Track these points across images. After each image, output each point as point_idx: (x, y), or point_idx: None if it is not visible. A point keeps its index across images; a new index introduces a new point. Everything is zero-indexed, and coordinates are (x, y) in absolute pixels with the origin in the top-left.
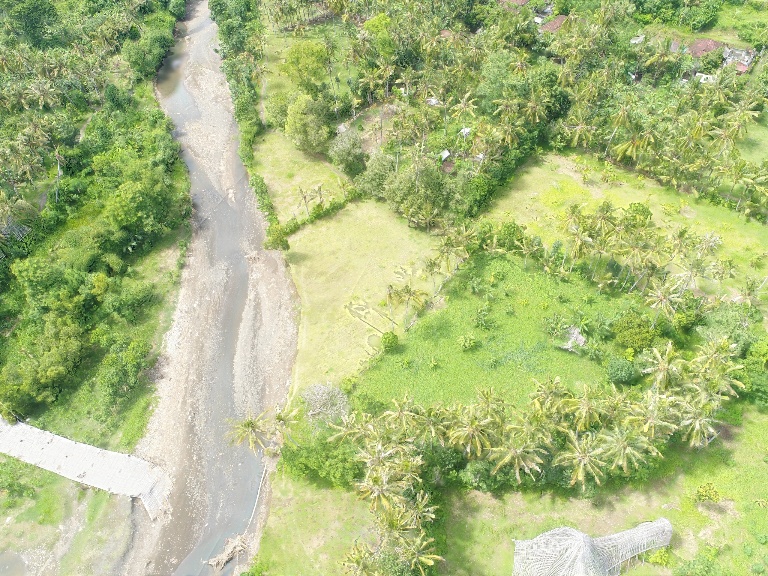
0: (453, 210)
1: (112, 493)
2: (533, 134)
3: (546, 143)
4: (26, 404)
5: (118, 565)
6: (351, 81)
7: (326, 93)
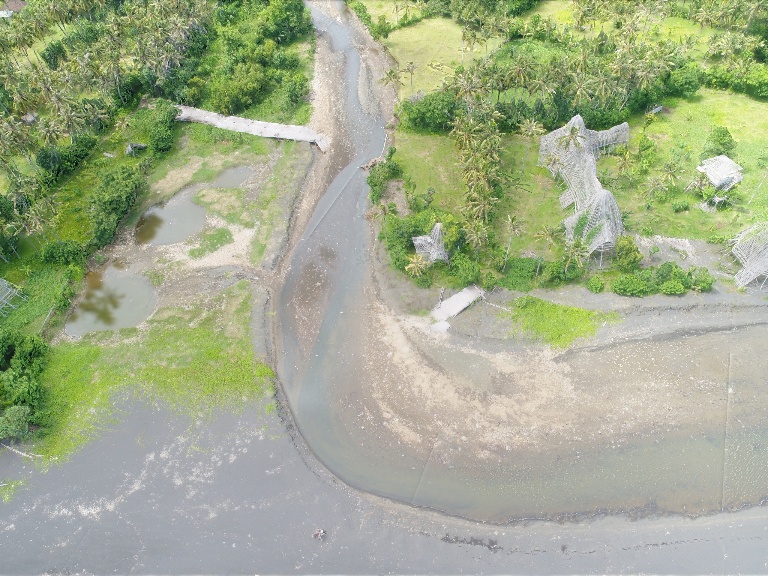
0: (498, 12)
1: (297, 141)
2: None
3: None
4: (234, 104)
5: (308, 167)
6: None
7: None
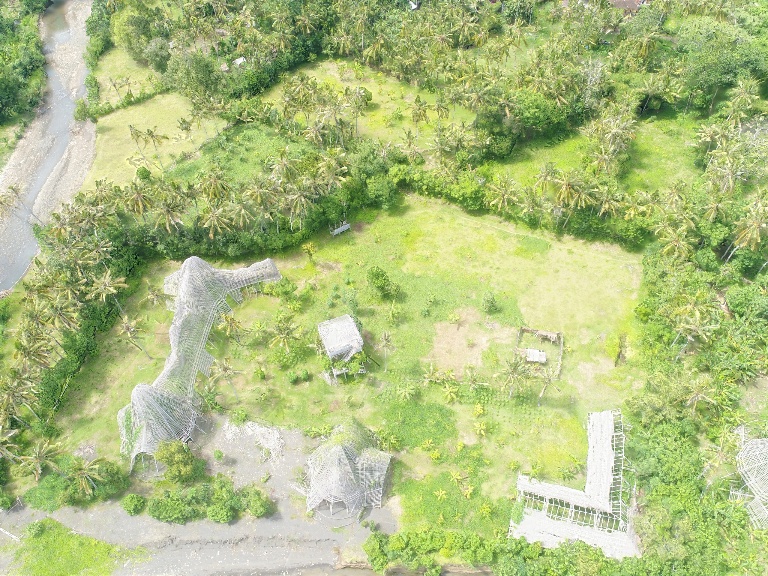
0: (221, 92)
1: None
2: (307, 43)
3: (326, 54)
4: None
5: None
6: (183, 8)
7: (161, 16)
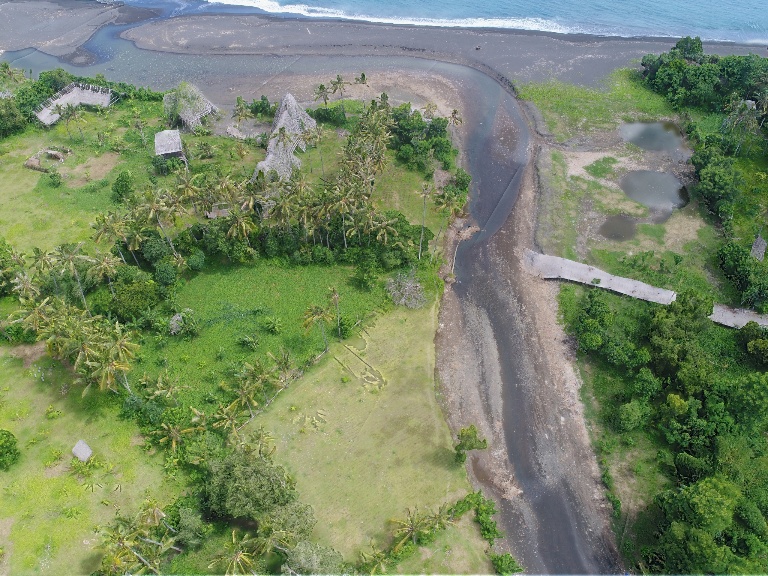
0: None
1: None
2: None
3: None
4: None
5: None
6: None
7: None
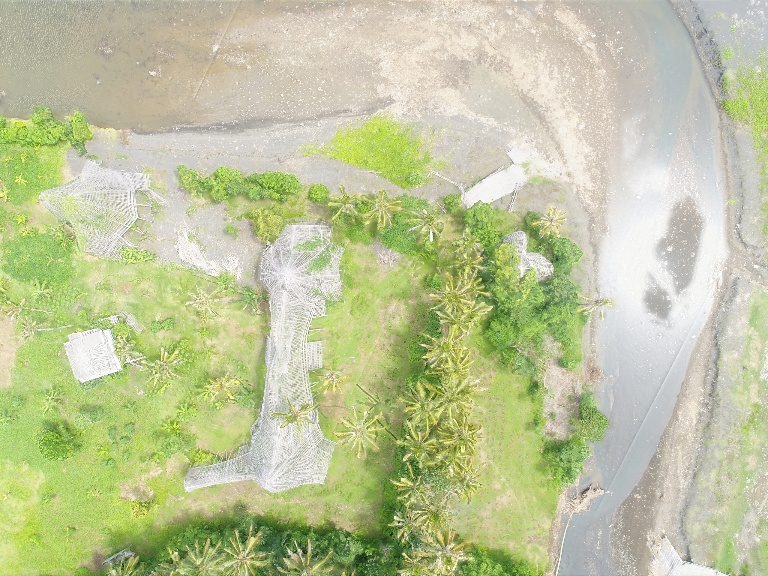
0: None
1: (713, 569)
2: None
3: None
4: None
5: (691, 498)
6: None
7: None
